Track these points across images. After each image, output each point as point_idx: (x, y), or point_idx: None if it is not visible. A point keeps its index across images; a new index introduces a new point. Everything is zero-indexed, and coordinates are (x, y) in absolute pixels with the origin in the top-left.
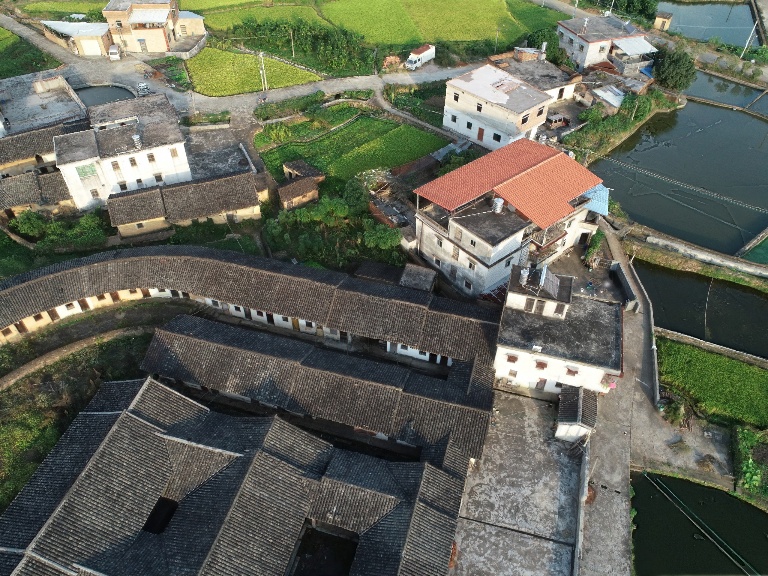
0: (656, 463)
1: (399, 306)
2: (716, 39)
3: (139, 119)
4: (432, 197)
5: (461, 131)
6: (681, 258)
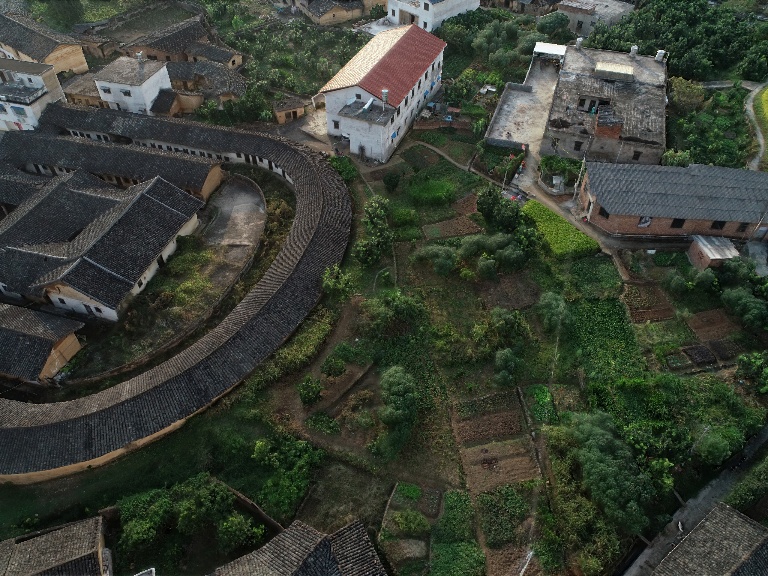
0: None
1: None
2: None
3: None
4: None
5: None
6: None
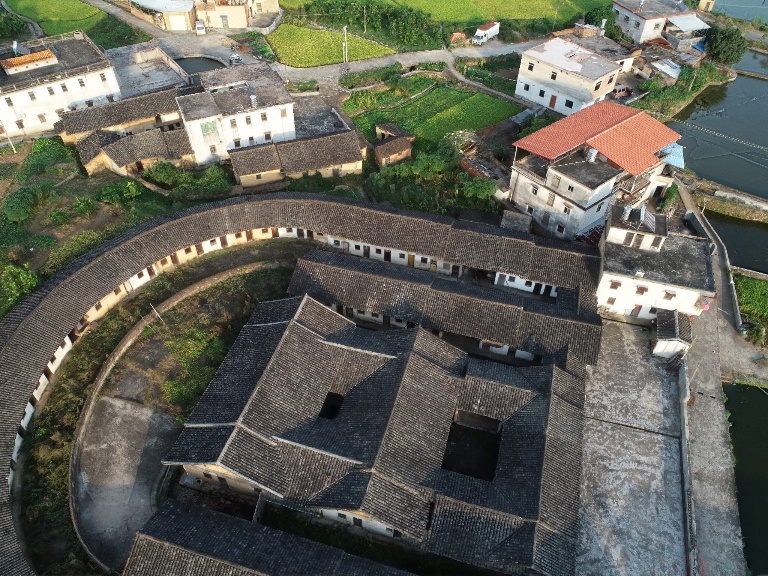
0: (743, 375)
1: (508, 242)
2: (759, 19)
3: (248, 83)
4: (532, 148)
5: (533, 99)
6: (749, 208)
